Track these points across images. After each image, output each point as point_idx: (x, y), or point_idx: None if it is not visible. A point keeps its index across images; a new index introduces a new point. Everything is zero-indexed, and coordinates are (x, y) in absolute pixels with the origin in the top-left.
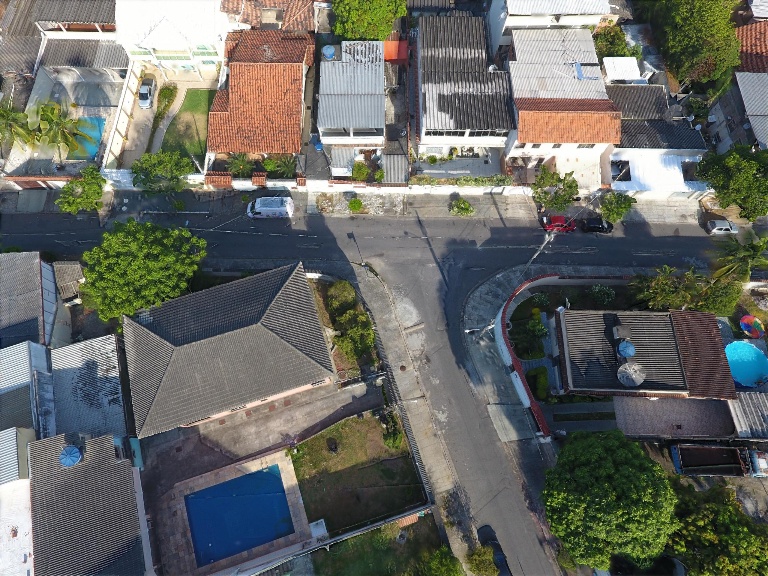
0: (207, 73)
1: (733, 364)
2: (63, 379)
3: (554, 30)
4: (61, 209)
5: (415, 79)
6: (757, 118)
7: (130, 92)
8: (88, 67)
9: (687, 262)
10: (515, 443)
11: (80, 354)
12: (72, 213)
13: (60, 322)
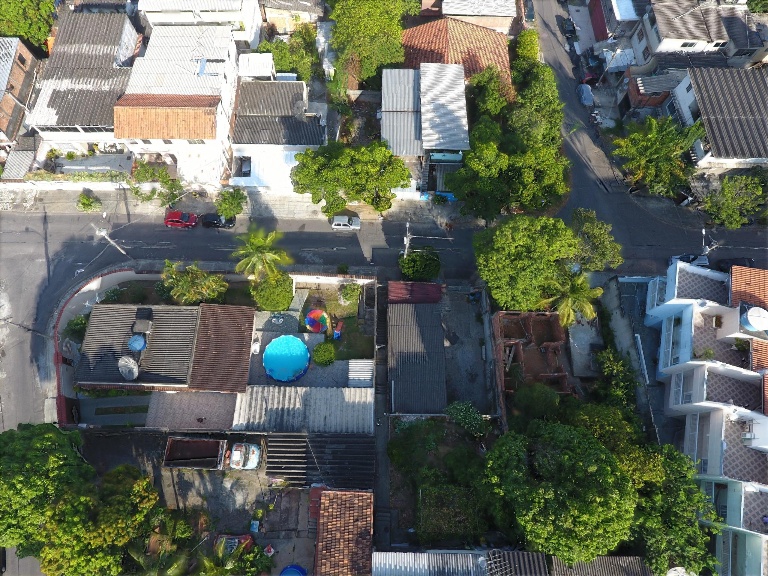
0: None
1: (280, 358)
2: None
3: (195, 26)
4: None
5: None
6: (390, 114)
7: None
8: None
9: (303, 257)
10: None
11: None
12: None
13: None
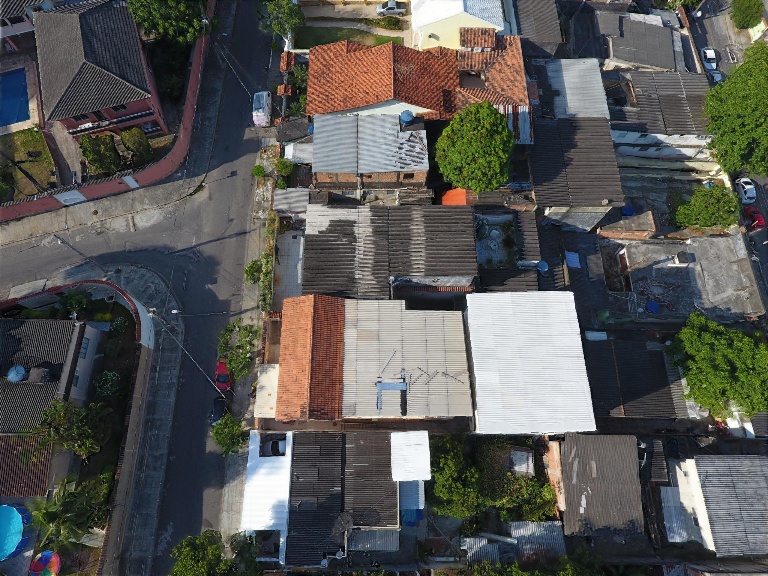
0: None
1: (6, 523)
2: None
3: (465, 365)
4: None
5: None
6: None
7: None
8: None
9: (166, 528)
10: (6, 298)
11: None
12: None
13: None
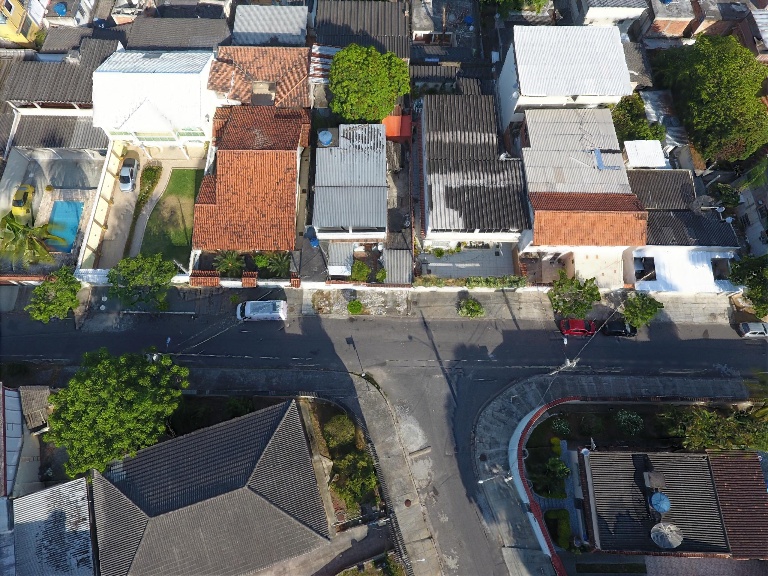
0: (194, 150)
1: None
2: (26, 536)
3: (571, 110)
4: (31, 316)
5: (419, 162)
6: None
7: (110, 175)
8: (64, 147)
9: (718, 370)
10: None
11: (46, 504)
12: (43, 322)
13: (26, 460)
